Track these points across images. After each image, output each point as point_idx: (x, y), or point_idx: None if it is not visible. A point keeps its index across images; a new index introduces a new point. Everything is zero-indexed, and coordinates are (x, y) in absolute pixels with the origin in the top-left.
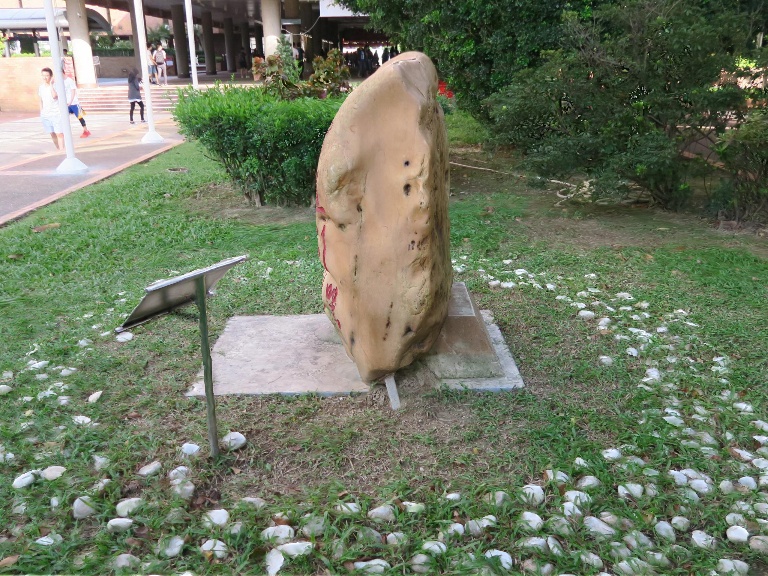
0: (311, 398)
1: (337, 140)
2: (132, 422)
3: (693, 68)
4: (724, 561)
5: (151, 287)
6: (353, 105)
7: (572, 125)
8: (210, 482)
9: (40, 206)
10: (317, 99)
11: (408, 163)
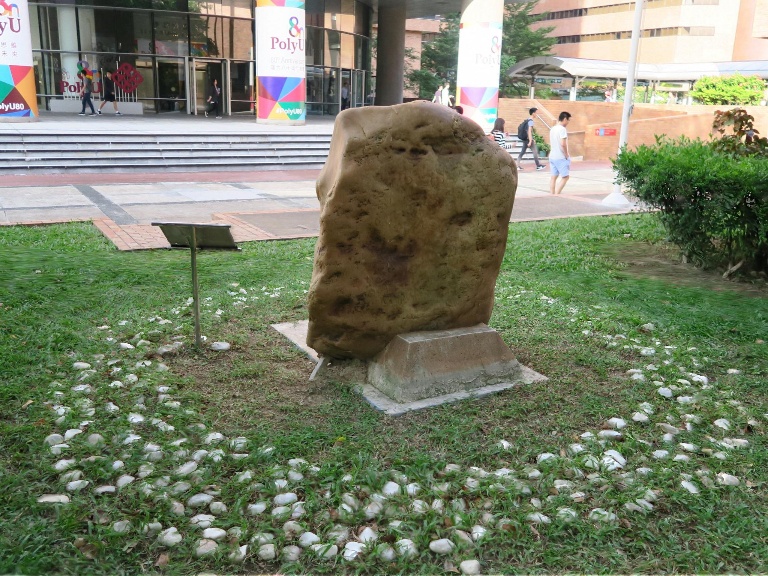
0: (302, 355)
1: None
2: (230, 323)
3: None
4: (171, 528)
5: (156, 222)
6: None
7: None
8: (179, 355)
9: (523, 221)
10: (739, 158)
11: None
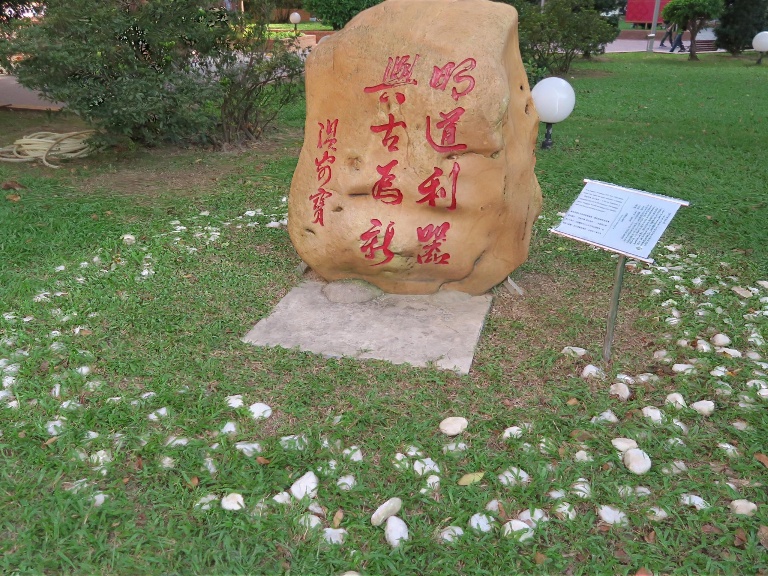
0: None
1: (498, 74)
2: None
3: (183, 8)
4: (693, 256)
5: None
6: (501, 40)
7: (104, 71)
8: None
9: None
10: None
11: (522, 87)
